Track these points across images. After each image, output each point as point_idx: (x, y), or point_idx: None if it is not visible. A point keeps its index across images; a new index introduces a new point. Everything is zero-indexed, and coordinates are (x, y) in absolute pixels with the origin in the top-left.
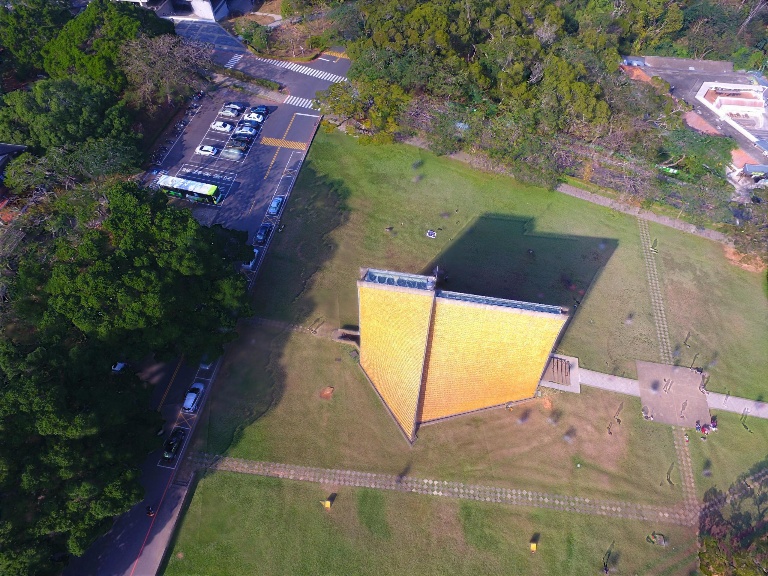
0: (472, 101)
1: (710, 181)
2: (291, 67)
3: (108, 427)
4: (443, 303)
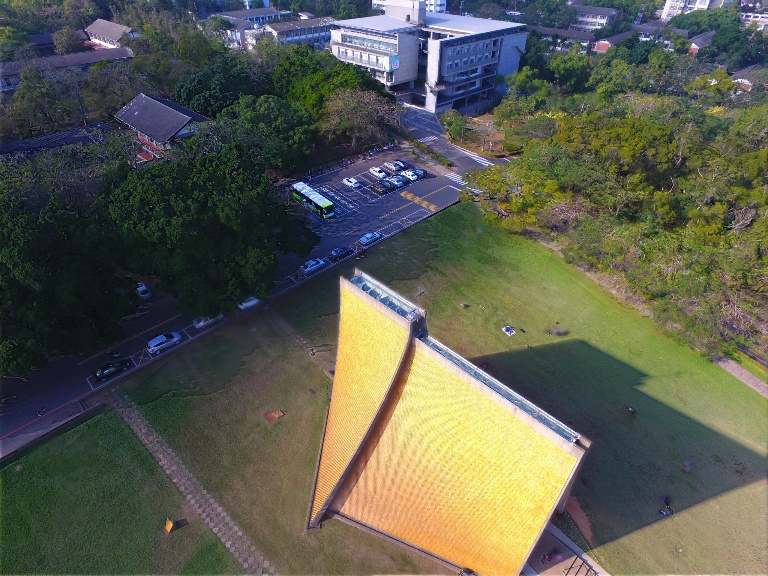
0: None
1: None
2: (473, 156)
3: (57, 297)
4: (423, 352)
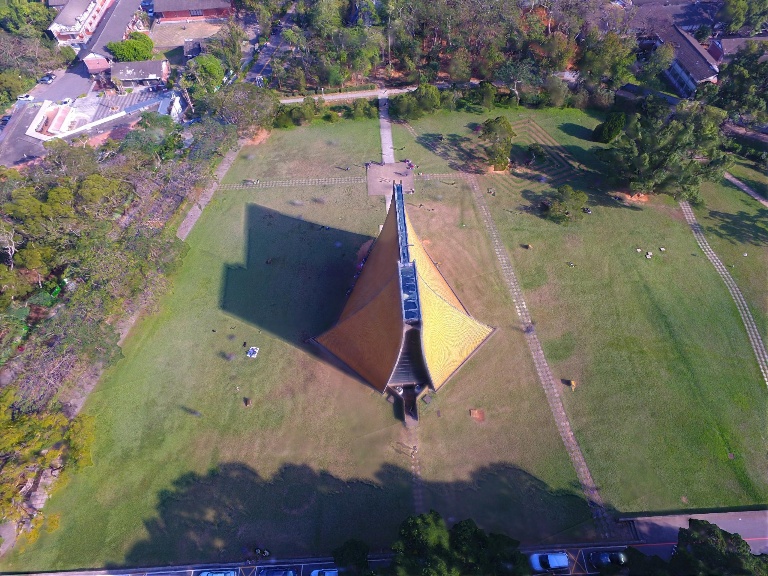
0: None
1: (197, 129)
2: None
3: None
4: None
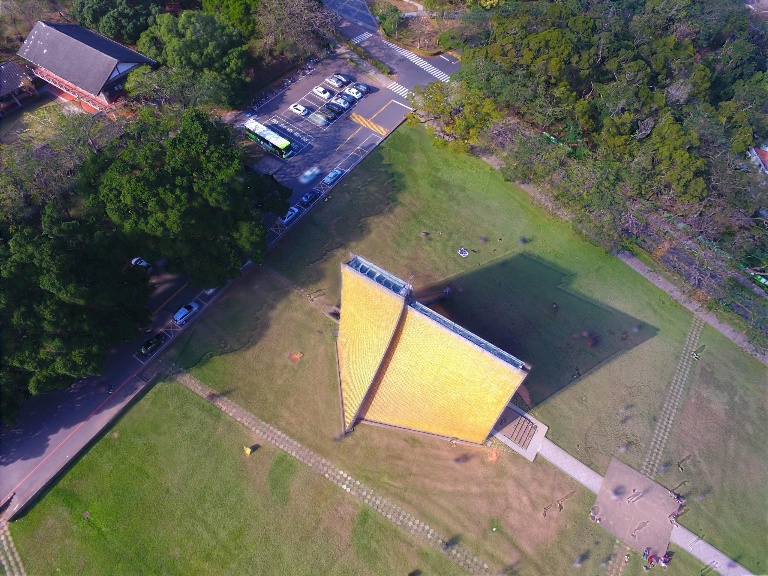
0: (566, 138)
1: None
2: (410, 57)
3: (97, 305)
4: (414, 314)
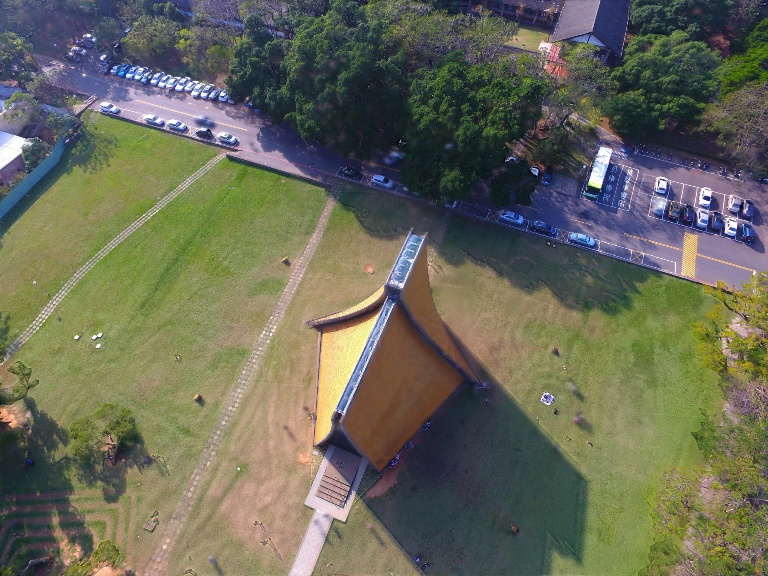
0: None
1: None
2: None
3: None
4: None
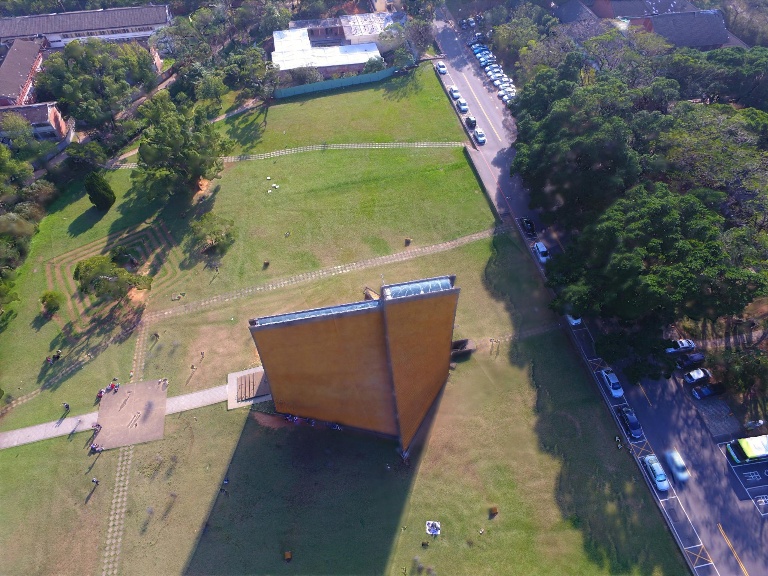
0: None
1: None
2: None
3: None
4: None
